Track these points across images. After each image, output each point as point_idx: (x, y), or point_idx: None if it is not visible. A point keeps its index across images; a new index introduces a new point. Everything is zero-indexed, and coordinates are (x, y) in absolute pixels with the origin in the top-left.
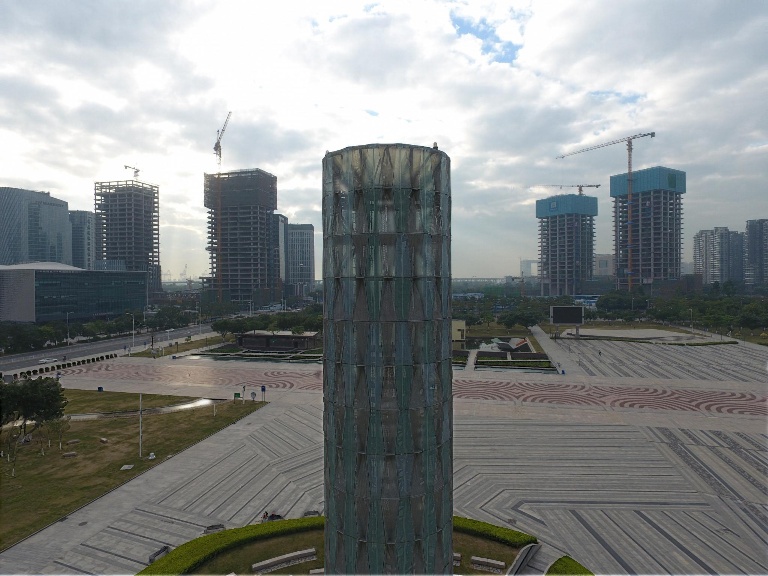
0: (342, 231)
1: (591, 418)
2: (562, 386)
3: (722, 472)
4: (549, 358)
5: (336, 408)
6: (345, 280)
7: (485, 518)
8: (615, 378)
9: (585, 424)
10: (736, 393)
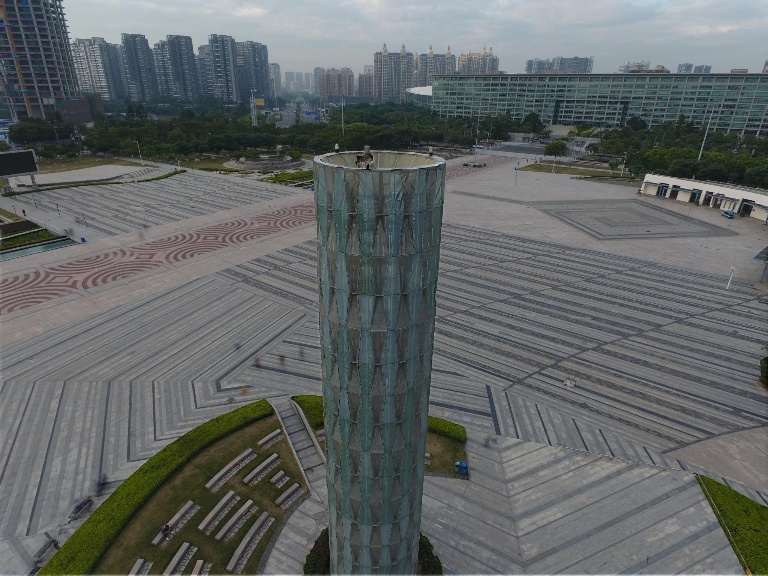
0: (412, 251)
1: (170, 282)
2: (102, 257)
3: (289, 289)
4: (41, 225)
5: (397, 397)
6: (412, 294)
7: (211, 412)
8: (138, 232)
9: (172, 290)
10: (233, 222)
